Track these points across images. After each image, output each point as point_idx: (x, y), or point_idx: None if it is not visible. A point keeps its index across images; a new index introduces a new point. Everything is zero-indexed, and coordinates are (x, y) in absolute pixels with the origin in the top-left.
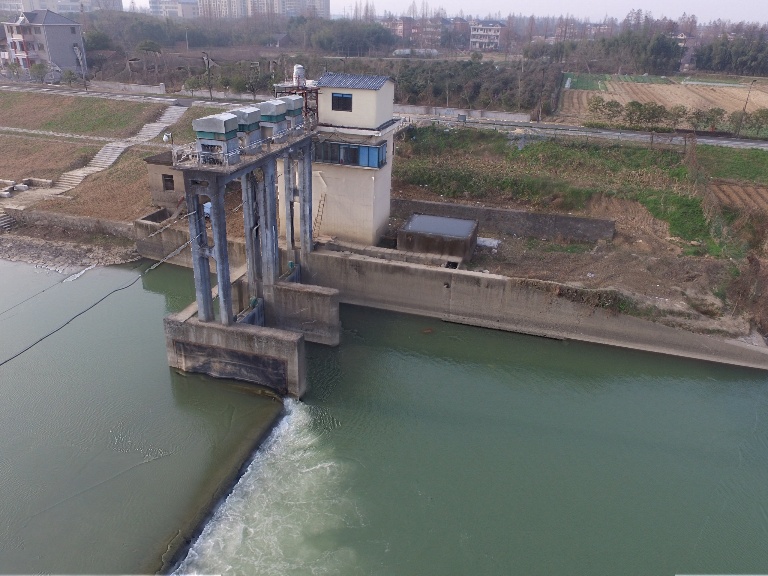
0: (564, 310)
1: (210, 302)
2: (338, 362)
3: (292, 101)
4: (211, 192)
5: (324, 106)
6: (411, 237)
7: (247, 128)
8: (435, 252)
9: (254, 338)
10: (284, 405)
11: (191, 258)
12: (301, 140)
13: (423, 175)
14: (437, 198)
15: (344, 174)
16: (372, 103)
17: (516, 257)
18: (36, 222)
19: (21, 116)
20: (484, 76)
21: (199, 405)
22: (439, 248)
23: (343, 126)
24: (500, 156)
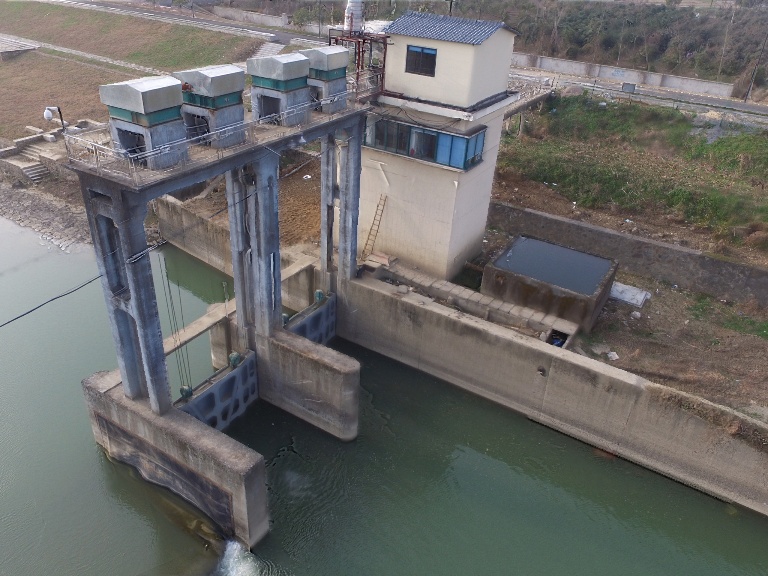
0: (739, 460)
1: (140, 372)
2: (355, 457)
3: (324, 56)
4: (116, 215)
5: (394, 64)
6: (503, 279)
7: (211, 102)
8: (536, 307)
9: (187, 447)
10: (224, 555)
11: (212, 254)
12: (331, 121)
13: (553, 169)
14: (566, 206)
15: (414, 171)
16: (466, 66)
17: (670, 331)
18: (68, 177)
19: (113, 43)
20: (675, 27)
21: (131, 502)
22: (543, 303)
23: (419, 98)
24: (676, 150)
